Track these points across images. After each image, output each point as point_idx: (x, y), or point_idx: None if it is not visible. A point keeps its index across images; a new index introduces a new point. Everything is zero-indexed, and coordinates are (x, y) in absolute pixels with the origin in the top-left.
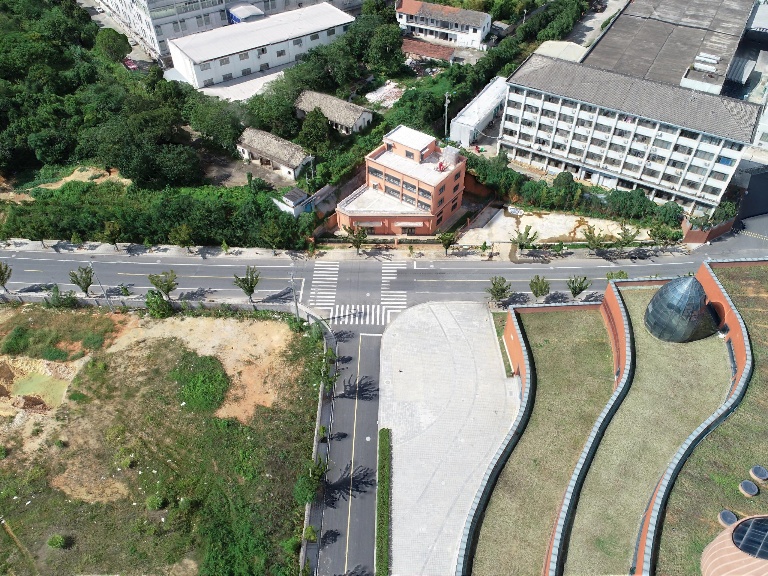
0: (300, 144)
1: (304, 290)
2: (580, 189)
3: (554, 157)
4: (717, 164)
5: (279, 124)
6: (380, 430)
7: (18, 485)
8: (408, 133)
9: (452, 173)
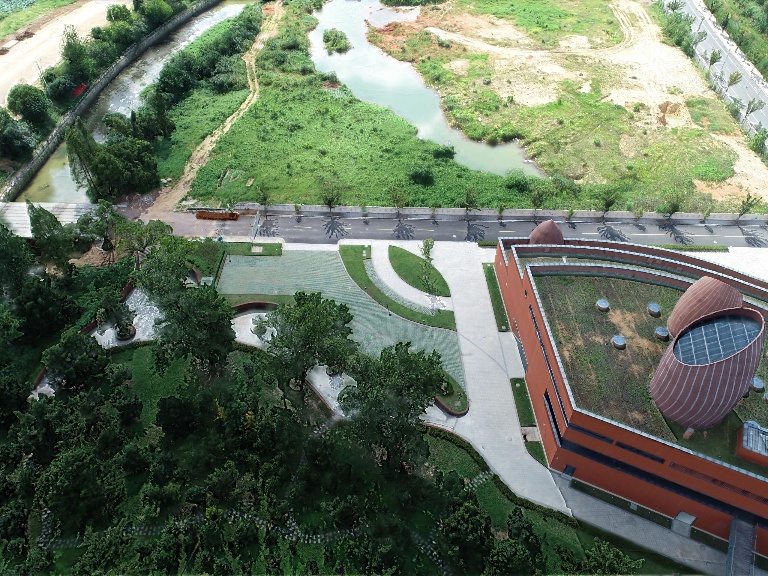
0: None
1: None
2: None
3: None
4: None
5: None
6: None
7: (617, 125)
8: None
9: None
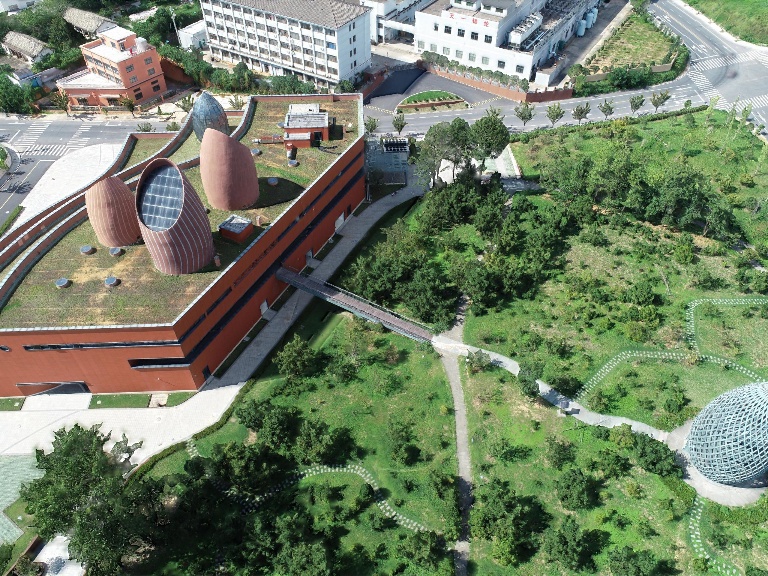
0: (52, 44)
1: (16, 136)
2: (248, 74)
3: (241, 54)
4: (328, 49)
5: (38, 29)
6: (16, 207)
7: None
8: (119, 31)
9: (139, 57)
